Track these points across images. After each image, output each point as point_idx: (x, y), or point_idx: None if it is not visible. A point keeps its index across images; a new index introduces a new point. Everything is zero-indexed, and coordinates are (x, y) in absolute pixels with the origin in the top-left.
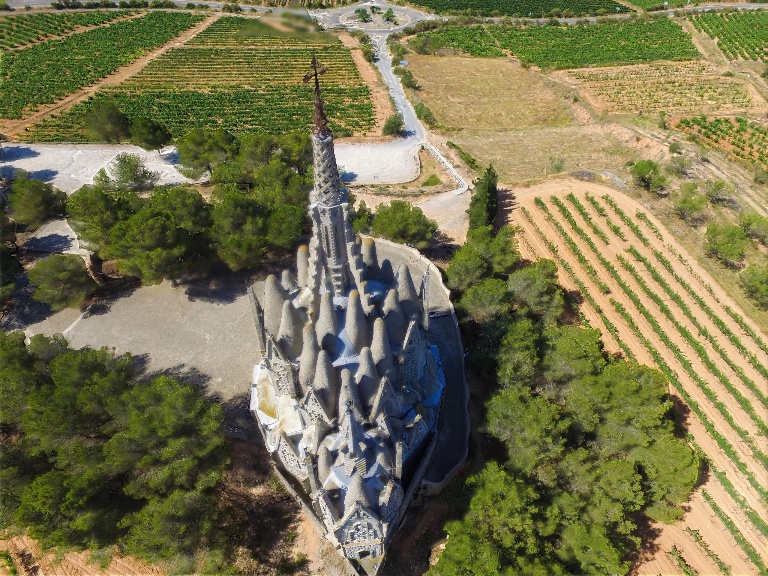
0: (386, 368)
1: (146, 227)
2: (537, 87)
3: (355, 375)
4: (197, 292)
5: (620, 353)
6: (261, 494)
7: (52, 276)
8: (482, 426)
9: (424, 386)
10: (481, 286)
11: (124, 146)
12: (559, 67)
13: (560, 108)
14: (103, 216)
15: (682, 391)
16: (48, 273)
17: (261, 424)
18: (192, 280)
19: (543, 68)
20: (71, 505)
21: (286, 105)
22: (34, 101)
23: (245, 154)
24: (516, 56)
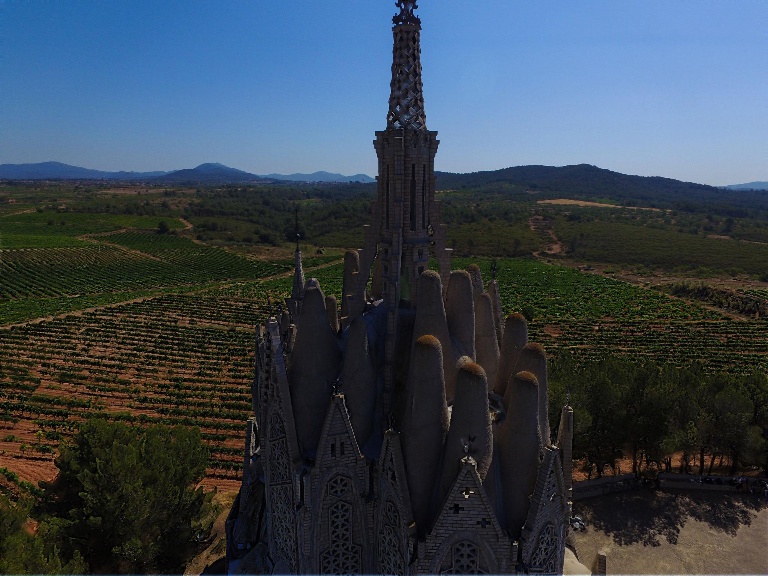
0: None
1: None
2: None
3: None
4: None
5: None
6: None
7: None
8: None
9: (261, 546)
10: None
11: None
12: None
13: None
14: None
15: None
16: None
17: None
18: None
19: None
20: None
21: None
22: None
23: None
24: None
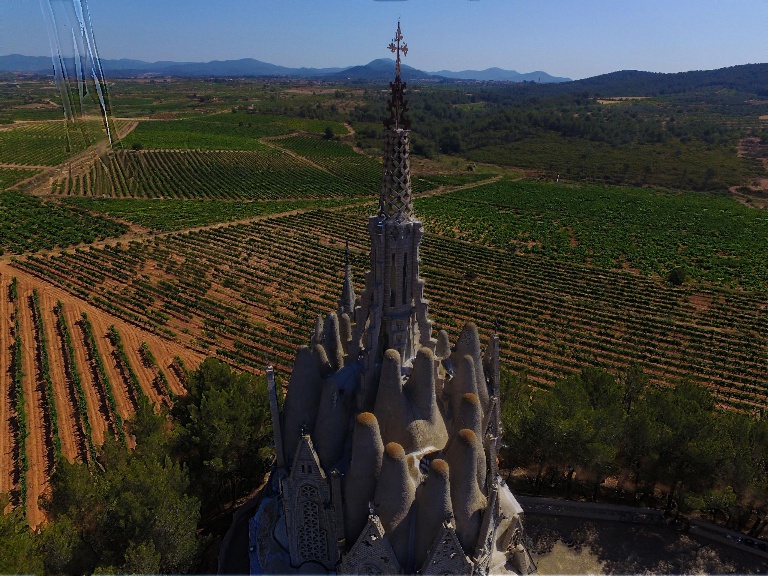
0: None
1: None
2: None
3: None
4: None
5: None
6: None
7: None
8: None
9: None
10: None
11: None
12: None
13: None
14: None
15: None
16: None
17: None
18: None
19: None
20: None
21: None
22: None
23: None
24: None
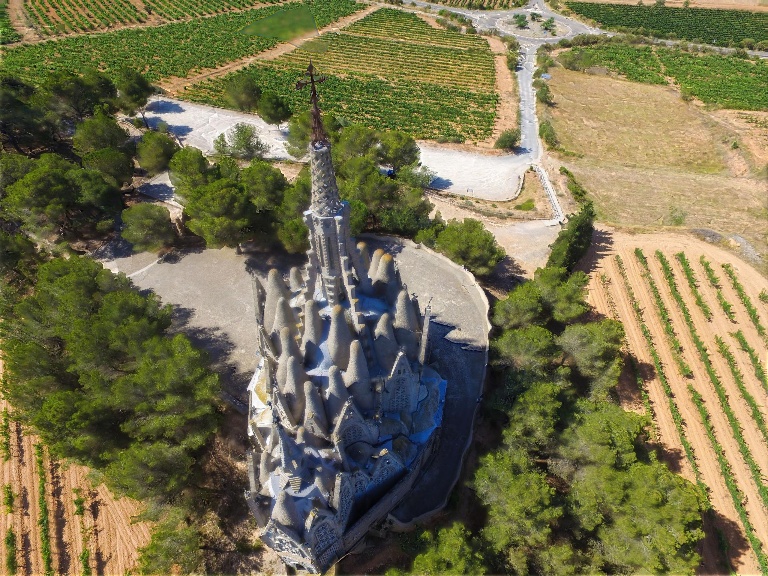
0: (360, 392)
1: (218, 195)
2: (692, 124)
3: (327, 389)
4: (255, 264)
5: (680, 450)
6: (243, 470)
7: (140, 221)
8: (472, 480)
9: (415, 420)
10: (521, 331)
11: (253, 116)
12: (728, 106)
13: (713, 152)
14: (196, 177)
15: (745, 521)
16: (138, 217)
17: (251, 406)
18: (255, 252)
19: (708, 104)
20: (75, 425)
21: (411, 101)
22: (201, 64)
23: (344, 143)
24: (680, 86)
